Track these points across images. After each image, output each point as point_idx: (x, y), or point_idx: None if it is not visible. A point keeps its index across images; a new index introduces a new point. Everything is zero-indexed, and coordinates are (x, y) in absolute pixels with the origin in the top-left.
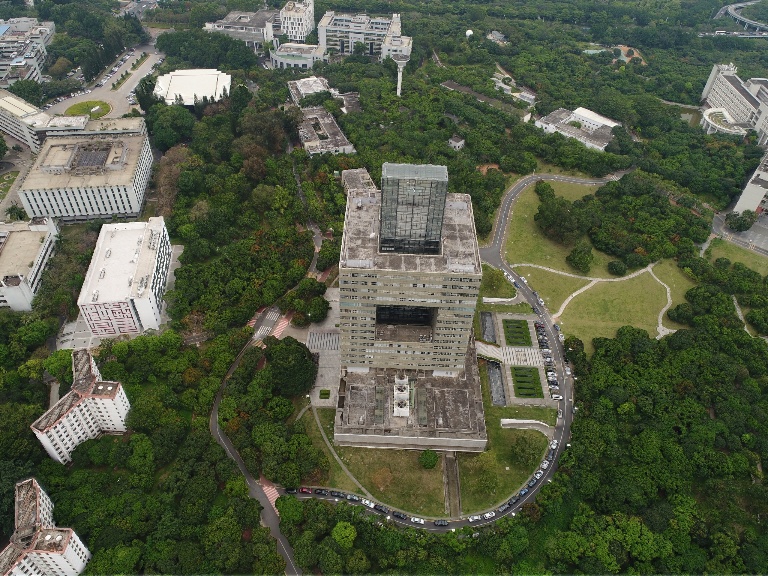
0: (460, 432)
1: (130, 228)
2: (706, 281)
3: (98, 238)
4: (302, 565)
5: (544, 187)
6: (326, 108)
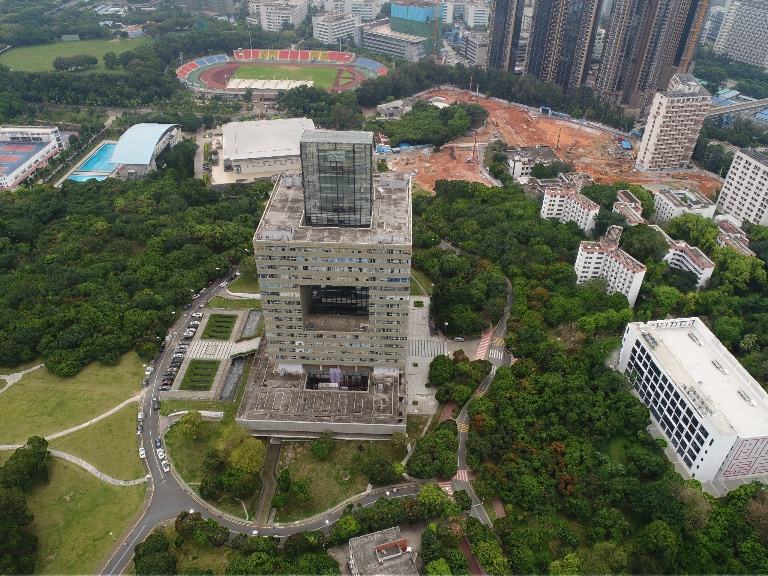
0: None
1: (763, 441)
2: None
3: None
4: None
5: None
6: None
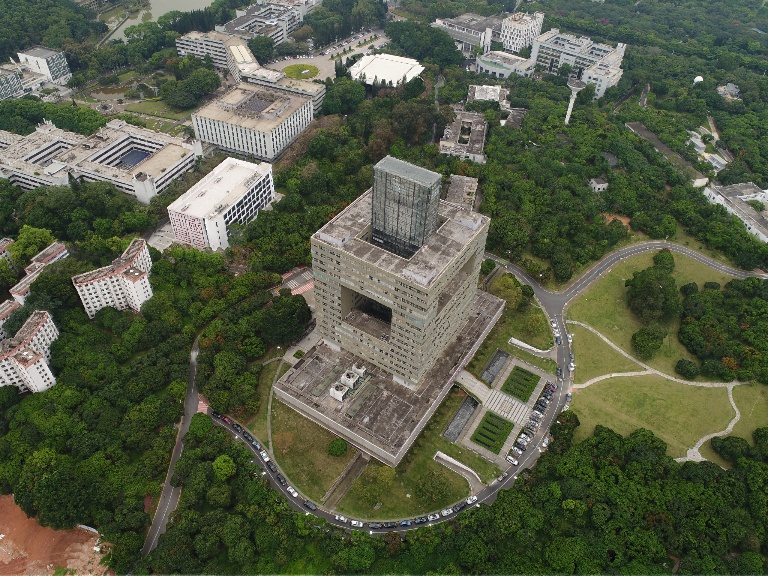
0: (377, 438)
1: (247, 166)
2: None
3: (217, 166)
4: (175, 470)
5: (664, 257)
6: (485, 116)
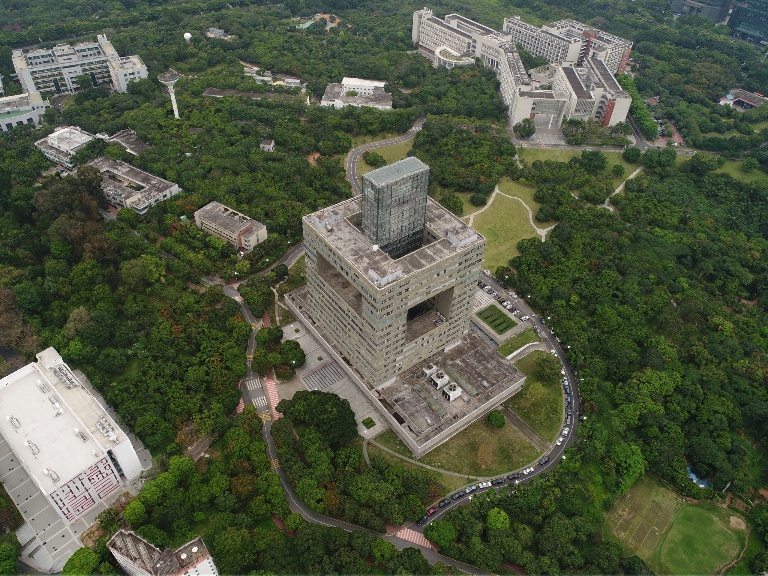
0: (504, 383)
1: (13, 380)
2: (539, 183)
3: None
4: (496, 567)
5: (374, 157)
6: (112, 156)
